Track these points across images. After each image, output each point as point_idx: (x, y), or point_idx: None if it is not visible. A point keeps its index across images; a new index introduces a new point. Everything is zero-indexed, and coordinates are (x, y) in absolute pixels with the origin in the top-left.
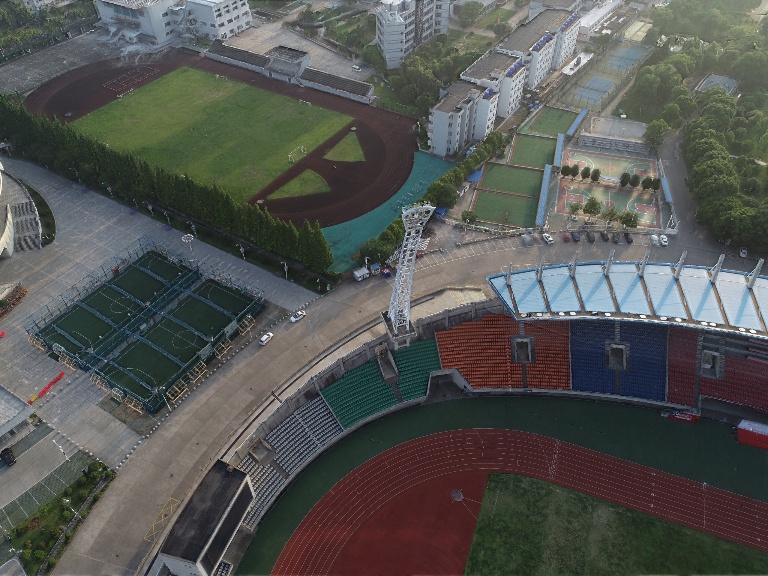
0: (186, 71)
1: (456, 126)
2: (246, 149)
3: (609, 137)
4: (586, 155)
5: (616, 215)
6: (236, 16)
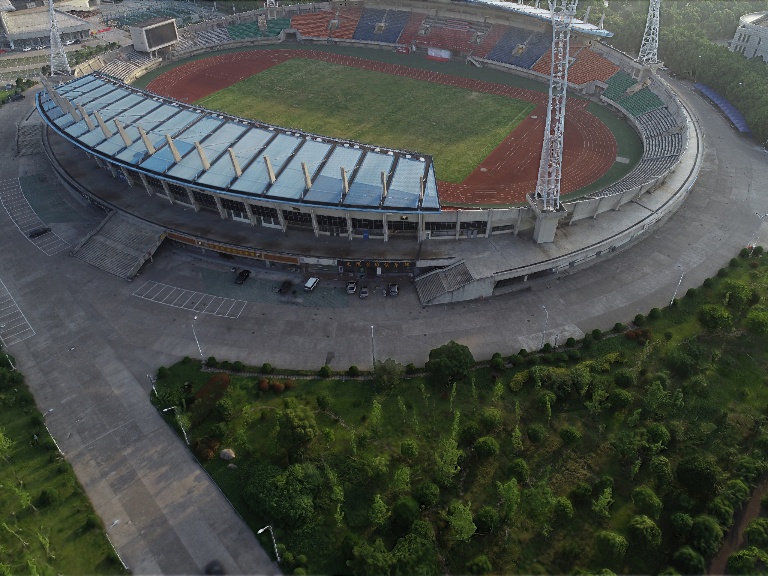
0: None
1: None
2: None
3: None
4: None
5: None
6: None
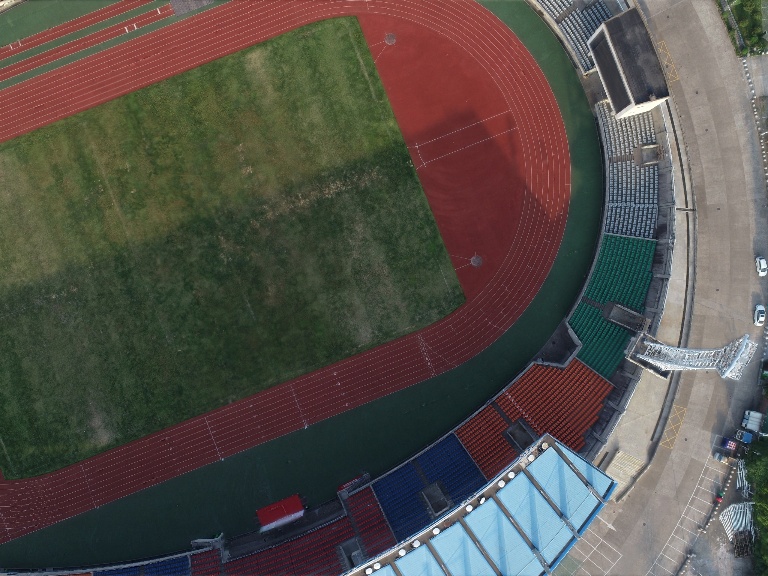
0: None
1: None
2: None
3: None
4: None
5: None
6: None
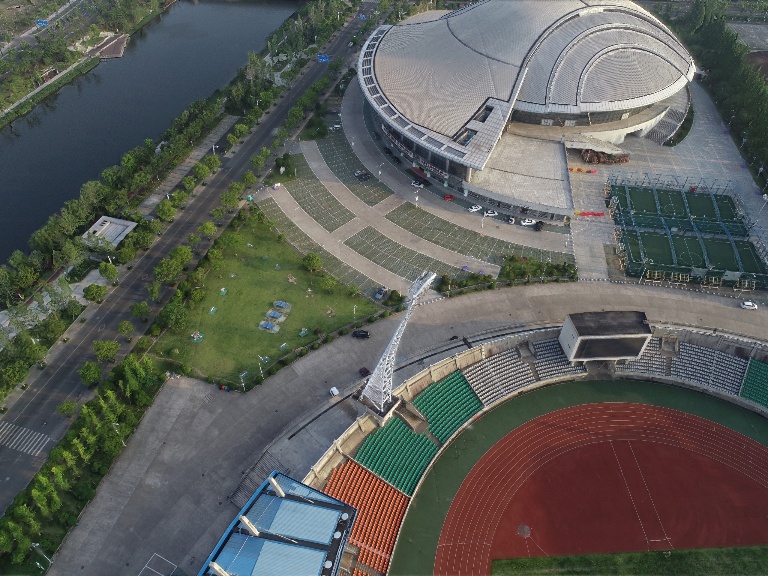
0: None
1: None
2: None
3: None
4: None
5: None
6: None
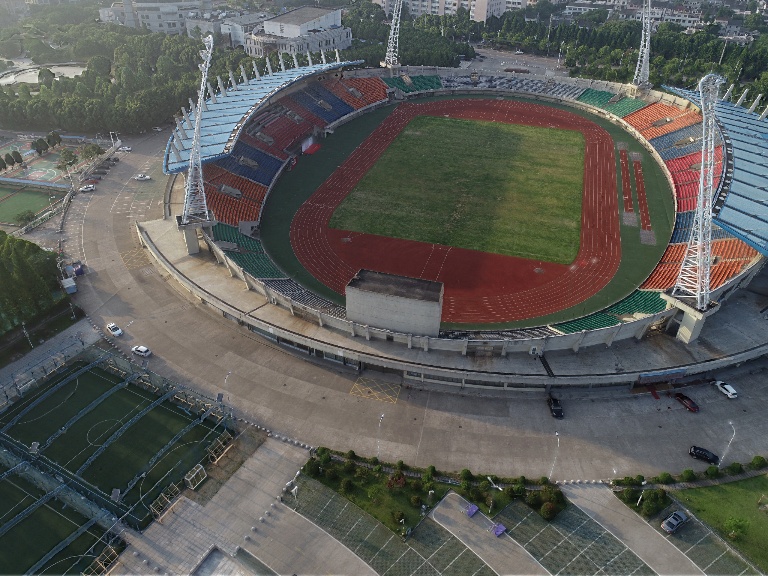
0: None
1: None
2: None
3: None
4: None
5: None
6: None
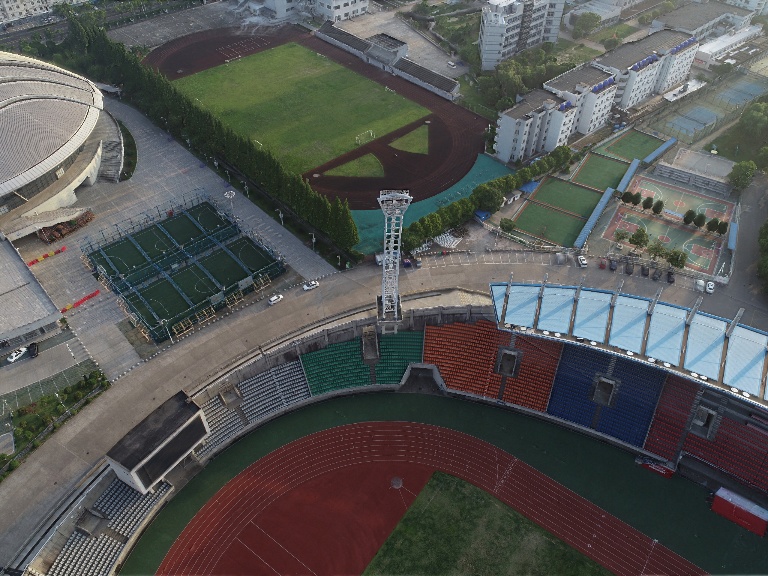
0: (293, 46)
1: (522, 134)
2: (321, 125)
3: (689, 171)
4: (658, 185)
5: (662, 251)
6: (353, 1)
